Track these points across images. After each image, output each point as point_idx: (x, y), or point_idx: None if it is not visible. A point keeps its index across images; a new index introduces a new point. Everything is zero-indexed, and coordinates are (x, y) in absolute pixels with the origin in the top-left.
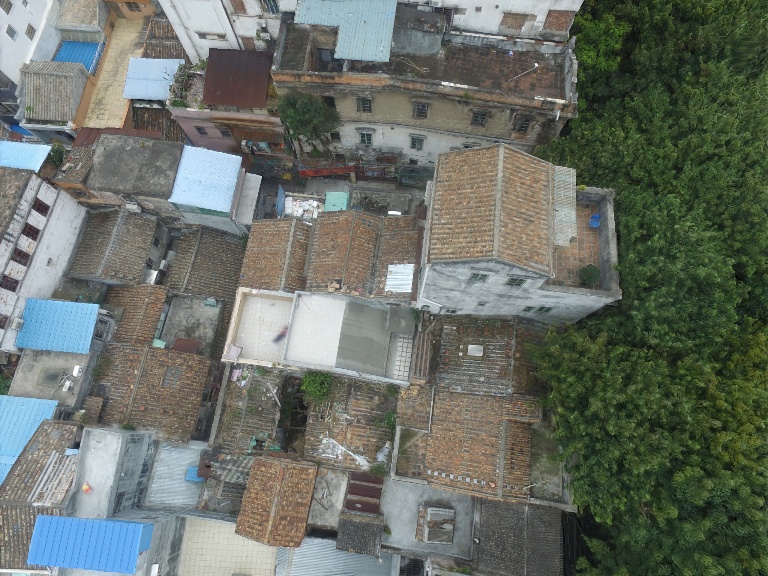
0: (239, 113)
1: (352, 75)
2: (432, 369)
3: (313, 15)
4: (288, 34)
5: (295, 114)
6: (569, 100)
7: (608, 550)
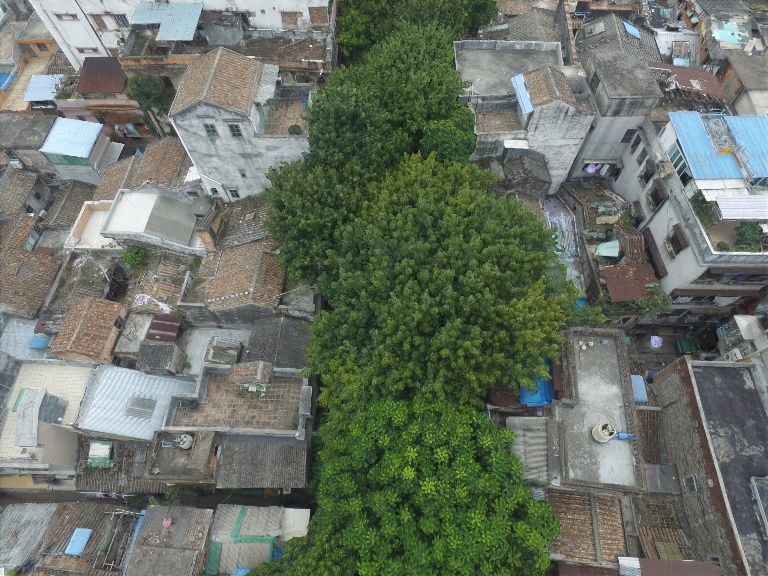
0: (106, 99)
1: (175, 56)
2: (221, 236)
3: (144, 18)
4: (137, 40)
5: (138, 87)
6: (325, 60)
7: None
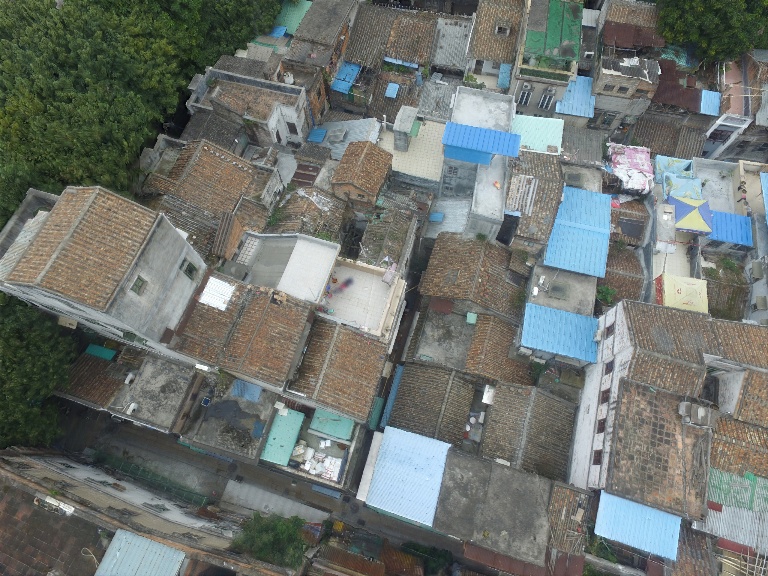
0: None
1: None
2: None
3: None
4: None
5: None
6: None
7: (151, 111)
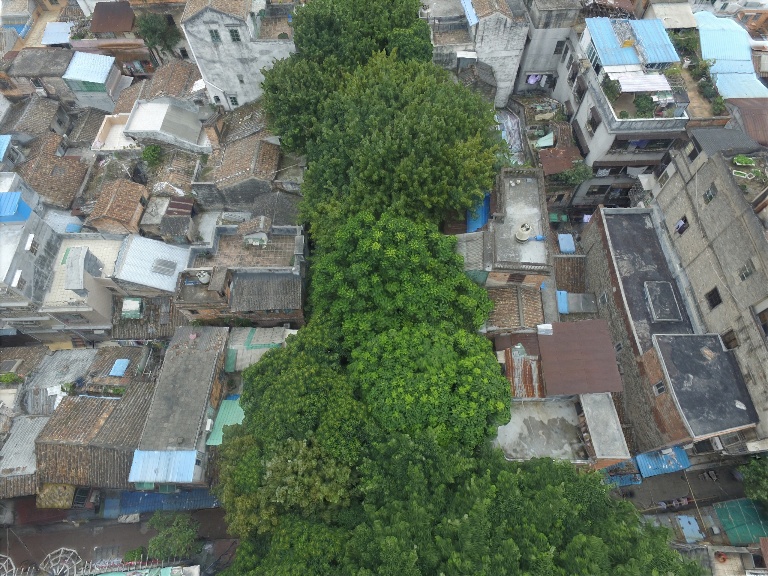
0: (116, 39)
1: None
2: (224, 136)
3: None
4: None
5: (145, 23)
6: None
7: None
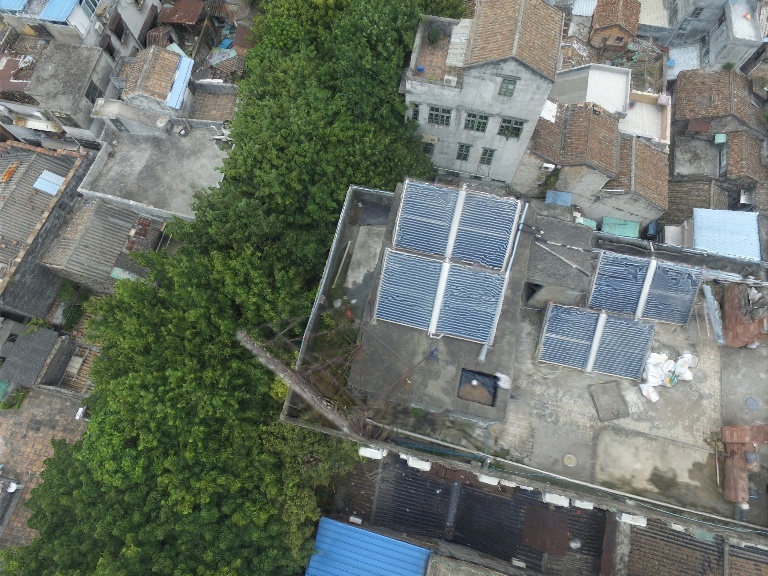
0: None
1: None
2: None
3: None
4: None
5: None
6: None
7: None
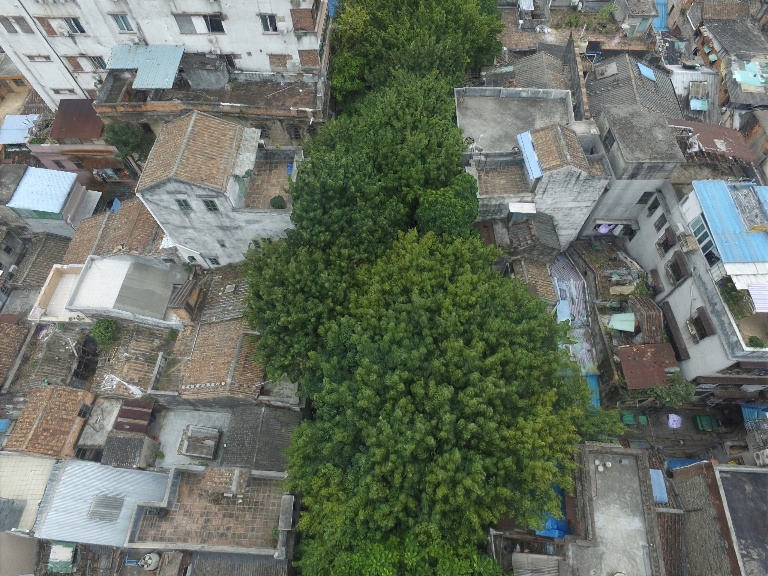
0: (83, 145)
1: (154, 103)
2: (199, 309)
3: (120, 63)
4: (115, 82)
5: (115, 136)
6: None
7: None
